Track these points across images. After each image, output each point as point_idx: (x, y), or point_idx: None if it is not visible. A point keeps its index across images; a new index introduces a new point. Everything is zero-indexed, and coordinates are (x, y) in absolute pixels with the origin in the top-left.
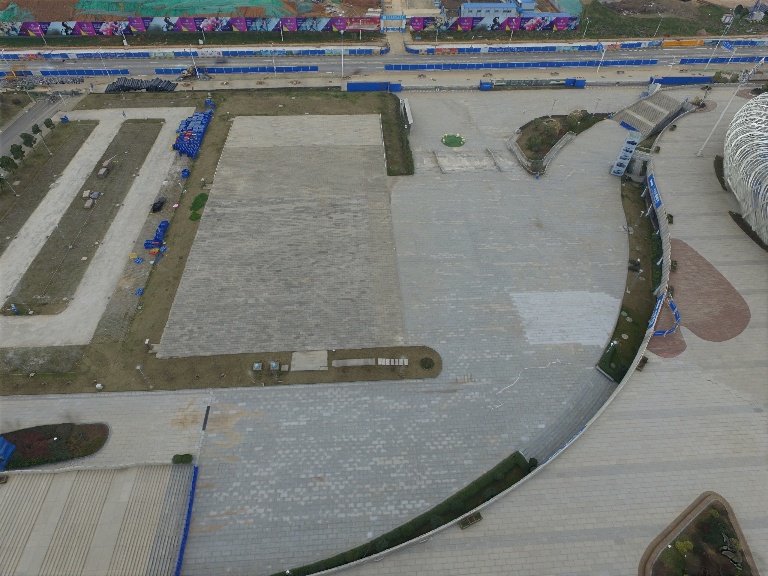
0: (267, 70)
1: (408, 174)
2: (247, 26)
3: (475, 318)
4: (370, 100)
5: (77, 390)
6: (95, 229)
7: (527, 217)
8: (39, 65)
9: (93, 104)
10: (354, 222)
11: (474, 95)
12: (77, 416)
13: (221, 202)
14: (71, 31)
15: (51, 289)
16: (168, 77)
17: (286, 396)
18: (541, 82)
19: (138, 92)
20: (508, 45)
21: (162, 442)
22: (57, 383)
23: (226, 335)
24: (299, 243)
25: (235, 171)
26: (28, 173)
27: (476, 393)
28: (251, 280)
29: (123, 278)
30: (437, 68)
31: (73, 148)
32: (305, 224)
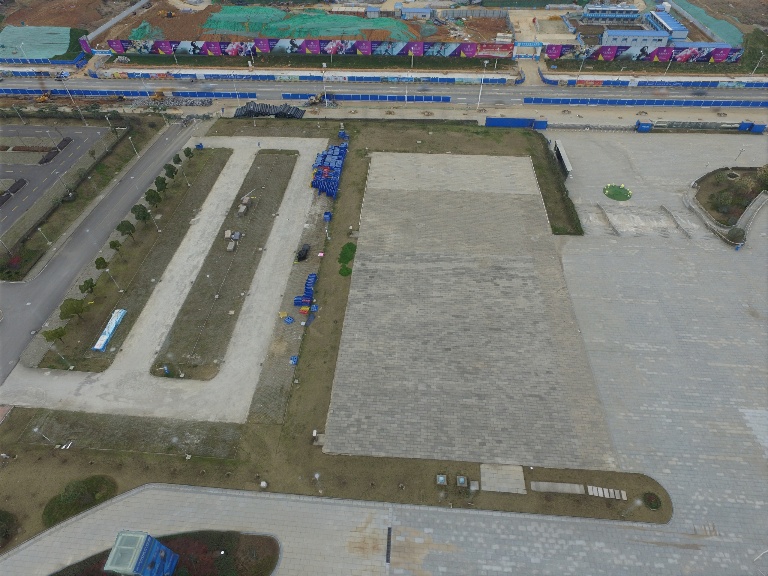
0: (396, 99)
1: (577, 234)
2: (372, 50)
3: (701, 440)
4: (516, 139)
5: (239, 485)
6: (240, 277)
7: (736, 302)
8: (169, 85)
9: (225, 130)
10: (525, 292)
11: (631, 137)
12: (242, 522)
13: (371, 255)
14: (198, 50)
15: (200, 347)
16: (295, 102)
17: (481, 526)
18: (710, 125)
19: (267, 118)
20: (658, 78)
21: (341, 573)
22: (216, 473)
23: (399, 431)
24: (466, 314)
25: (381, 218)
26: (169, 206)
27: (726, 555)
28: (418, 359)
29: (274, 341)
30: (582, 103)
31: (210, 179)
32: (469, 290)
